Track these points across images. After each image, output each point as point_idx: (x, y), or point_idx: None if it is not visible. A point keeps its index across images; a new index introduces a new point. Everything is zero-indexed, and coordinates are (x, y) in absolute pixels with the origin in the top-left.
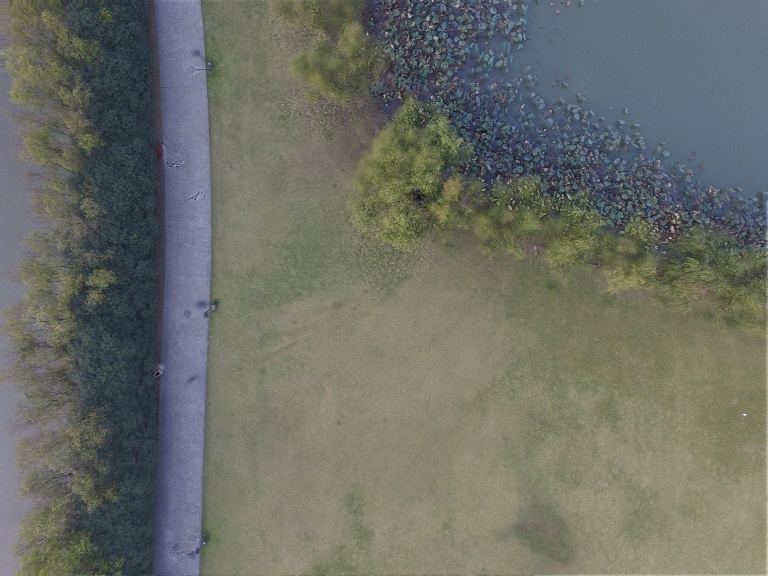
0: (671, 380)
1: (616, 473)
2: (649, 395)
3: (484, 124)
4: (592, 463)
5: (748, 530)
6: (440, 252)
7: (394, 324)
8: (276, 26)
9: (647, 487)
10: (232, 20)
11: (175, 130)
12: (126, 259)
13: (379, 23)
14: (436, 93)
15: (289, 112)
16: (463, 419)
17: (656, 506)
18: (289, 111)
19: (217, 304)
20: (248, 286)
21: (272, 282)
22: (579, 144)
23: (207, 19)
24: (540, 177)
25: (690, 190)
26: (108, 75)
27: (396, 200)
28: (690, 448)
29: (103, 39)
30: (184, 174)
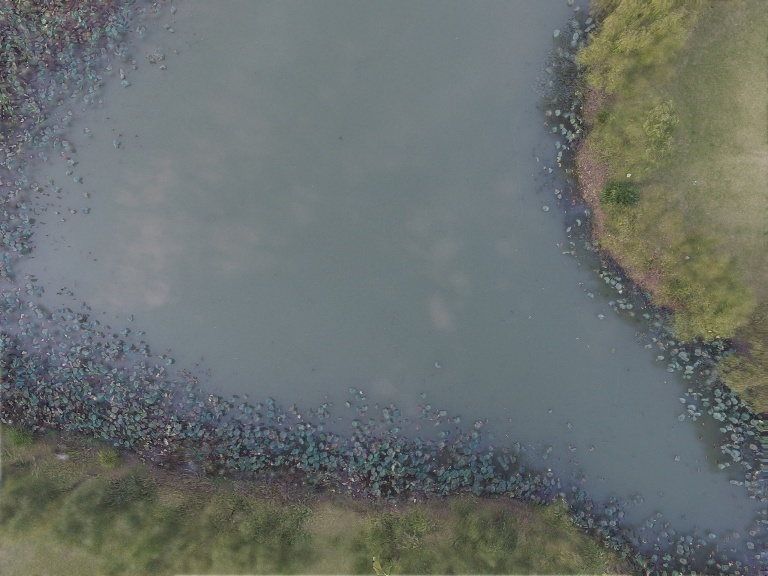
0: None
1: None
2: None
3: None
4: None
5: None
6: None
7: None
8: None
9: None
10: None
11: None
12: None
13: None
14: None
15: None
16: None
17: None
18: None
19: None
20: None
21: None
22: (75, 355)
23: None
24: (28, 392)
25: (184, 401)
26: None
27: None
28: None
29: None
30: None
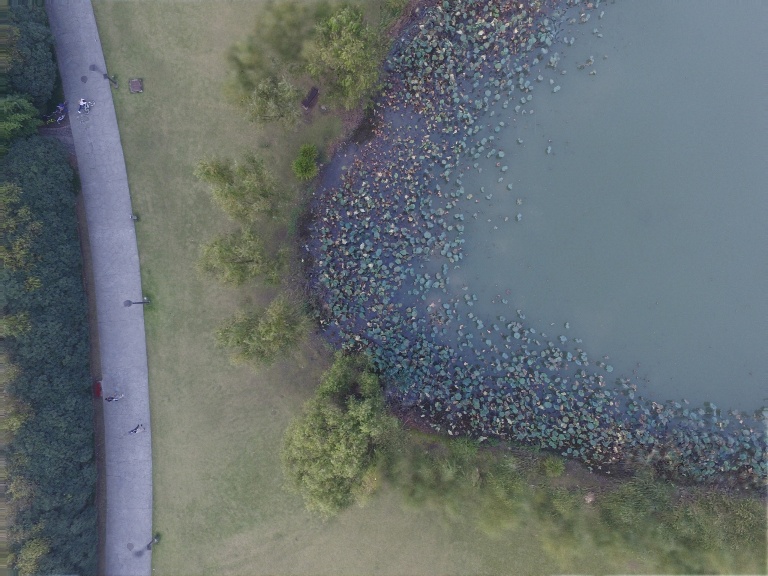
0: None
1: None
2: None
3: (421, 351)
4: None
5: None
6: (382, 476)
7: (336, 553)
8: (211, 255)
9: None
10: (167, 252)
11: (113, 364)
12: (60, 522)
13: (314, 249)
14: (372, 319)
15: (227, 341)
16: None
17: None
18: (227, 340)
19: (159, 537)
20: (189, 520)
21: (213, 515)
22: (518, 365)
23: (142, 252)
24: (479, 403)
25: (632, 409)
26: (37, 341)
27: (336, 426)
28: None
29: (32, 304)
30: (123, 408)
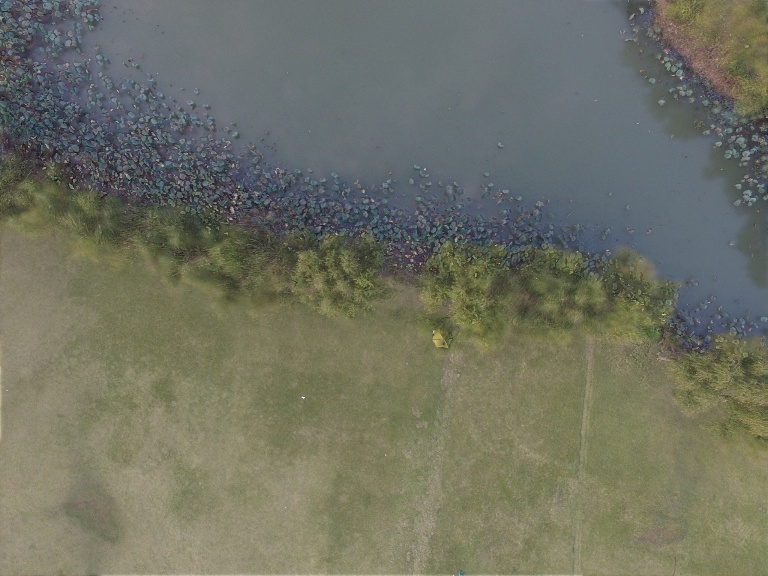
0: (230, 361)
1: (165, 453)
2: (206, 376)
3: (44, 103)
4: (143, 442)
5: (300, 514)
6: (6, 230)
7: None
8: None
9: (197, 468)
10: None
11: None
12: None
13: None
14: (0, 72)
15: None
16: (19, 396)
17: (205, 487)
18: None
19: None
20: None
21: None
22: (143, 124)
23: None
24: (97, 156)
25: (252, 171)
26: None
27: None
28: (244, 430)
29: None
30: None
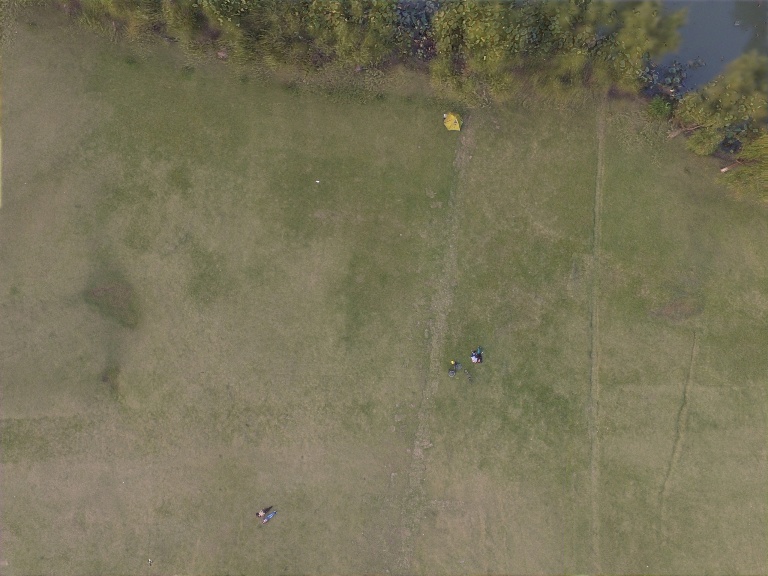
0: (245, 149)
1: (182, 237)
2: (221, 163)
3: None
4: (160, 228)
5: (317, 294)
6: (22, 30)
7: None
8: None
9: (214, 251)
10: None
11: None
12: None
13: None
14: None
15: None
16: (37, 188)
17: (222, 269)
18: None
19: None
20: None
21: None
22: None
23: None
24: None
25: None
26: None
27: None
28: (259, 213)
29: None
30: None
